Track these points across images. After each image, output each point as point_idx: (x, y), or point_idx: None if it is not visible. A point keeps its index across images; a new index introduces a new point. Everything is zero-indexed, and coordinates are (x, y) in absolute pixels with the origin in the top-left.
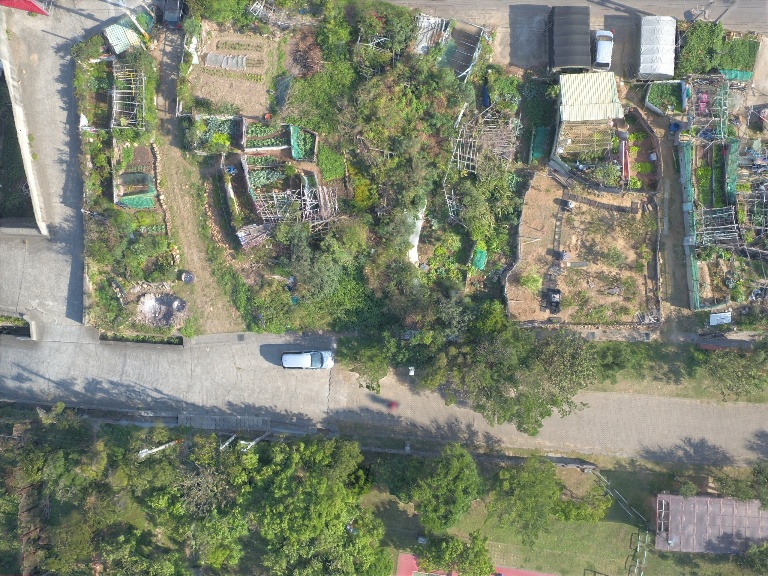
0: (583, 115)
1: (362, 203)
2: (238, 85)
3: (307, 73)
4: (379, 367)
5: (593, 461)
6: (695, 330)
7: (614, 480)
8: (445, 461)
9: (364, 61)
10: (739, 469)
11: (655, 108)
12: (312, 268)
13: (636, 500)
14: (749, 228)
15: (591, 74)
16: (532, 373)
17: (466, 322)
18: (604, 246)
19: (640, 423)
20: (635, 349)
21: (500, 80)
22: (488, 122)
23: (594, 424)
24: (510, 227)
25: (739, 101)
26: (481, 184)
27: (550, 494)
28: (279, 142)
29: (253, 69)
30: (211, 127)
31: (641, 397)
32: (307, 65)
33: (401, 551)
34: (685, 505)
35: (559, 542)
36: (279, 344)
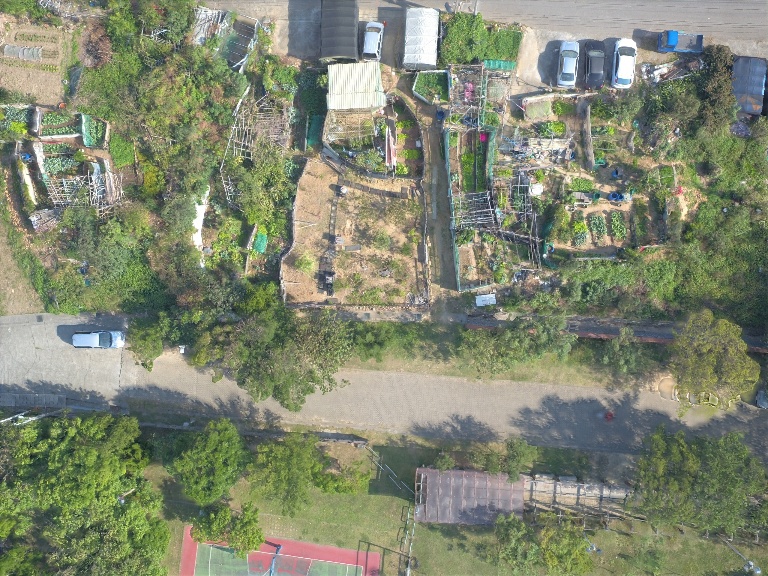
0: (348, 104)
1: (150, 189)
2: (35, 75)
3: (98, 64)
4: (154, 346)
5: (366, 437)
6: (463, 311)
7: (386, 455)
8: (205, 435)
9: (145, 52)
10: (503, 445)
11: (421, 97)
12: (95, 251)
13: (407, 474)
14: (510, 213)
15: (357, 64)
16: (285, 350)
17: (231, 302)
18: (377, 230)
19: (410, 400)
20: (407, 329)
21: (278, 70)
22: (263, 110)
23: (367, 401)
24: (288, 212)
25: (502, 90)
26: (256, 170)
27: (308, 467)
28: (73, 130)
29: (49, 60)
30: (9, 116)
31: (412, 375)
32: (98, 56)
33: (187, 523)
34: (442, 478)
35: (335, 515)
36: (75, 325)
